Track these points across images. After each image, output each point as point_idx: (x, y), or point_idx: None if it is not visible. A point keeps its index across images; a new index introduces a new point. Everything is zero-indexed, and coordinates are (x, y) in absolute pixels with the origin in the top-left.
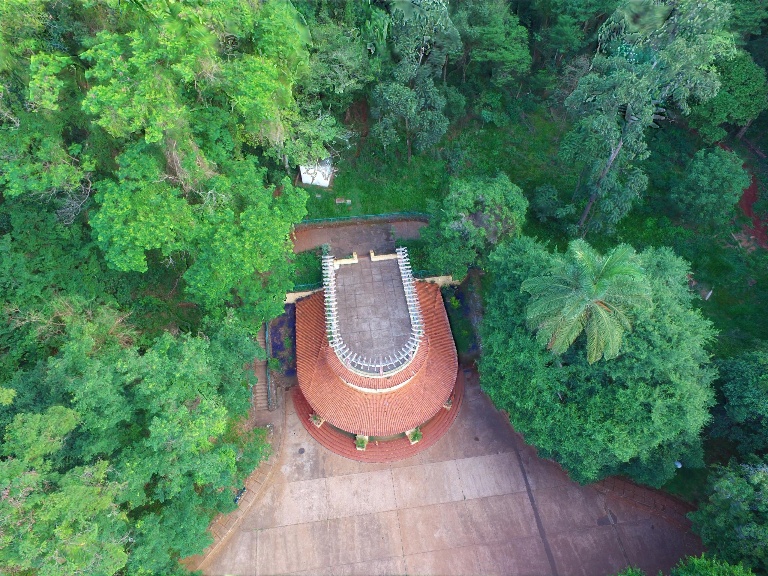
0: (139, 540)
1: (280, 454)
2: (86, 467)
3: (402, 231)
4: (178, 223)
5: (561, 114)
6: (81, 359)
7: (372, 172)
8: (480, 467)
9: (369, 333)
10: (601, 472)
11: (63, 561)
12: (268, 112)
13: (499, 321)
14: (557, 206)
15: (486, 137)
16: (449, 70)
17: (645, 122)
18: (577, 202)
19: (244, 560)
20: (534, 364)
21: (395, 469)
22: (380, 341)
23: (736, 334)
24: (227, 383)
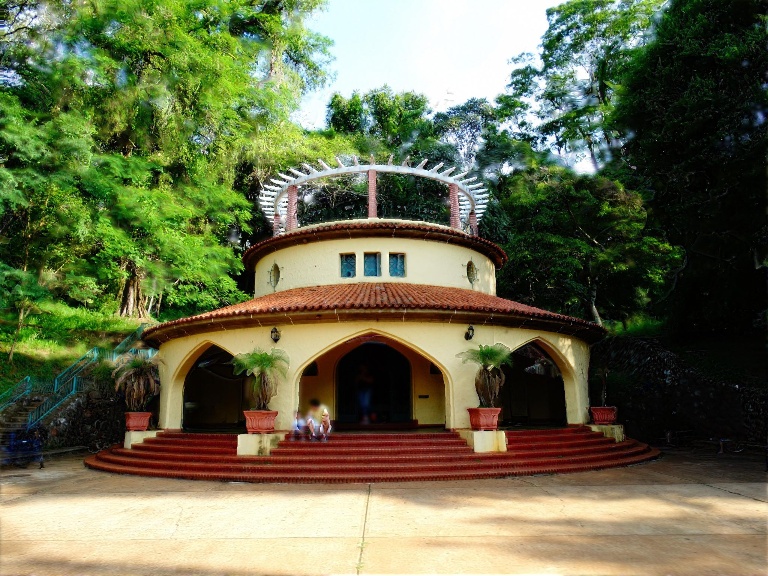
0: None
1: None
2: None
3: None
4: None
5: None
6: None
7: None
8: None
9: None
10: None
11: None
12: None
13: None
14: None
15: None
16: None
17: None
18: None
19: None
20: None
21: (389, 488)
22: None
23: None
24: None
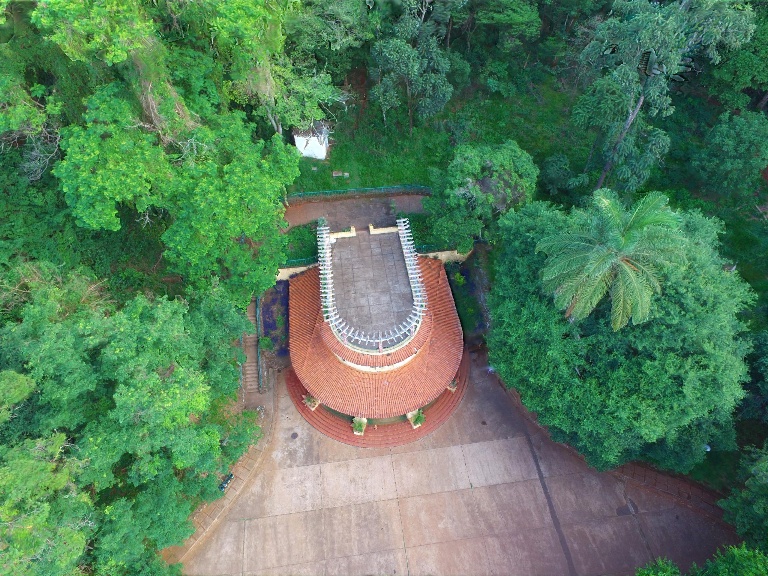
0: (108, 528)
1: (271, 439)
2: (39, 440)
3: (403, 205)
4: (153, 174)
5: (572, 81)
6: (43, 324)
7: (371, 144)
8: (488, 453)
9: (368, 308)
10: (621, 457)
11: (4, 547)
12: (252, 40)
13: (510, 290)
14: (569, 177)
15: (492, 108)
16: (453, 37)
17: (671, 71)
18: (589, 174)
19: (230, 553)
20: (550, 335)
21: (396, 455)
22: (379, 316)
23: (764, 310)
24: (213, 361)
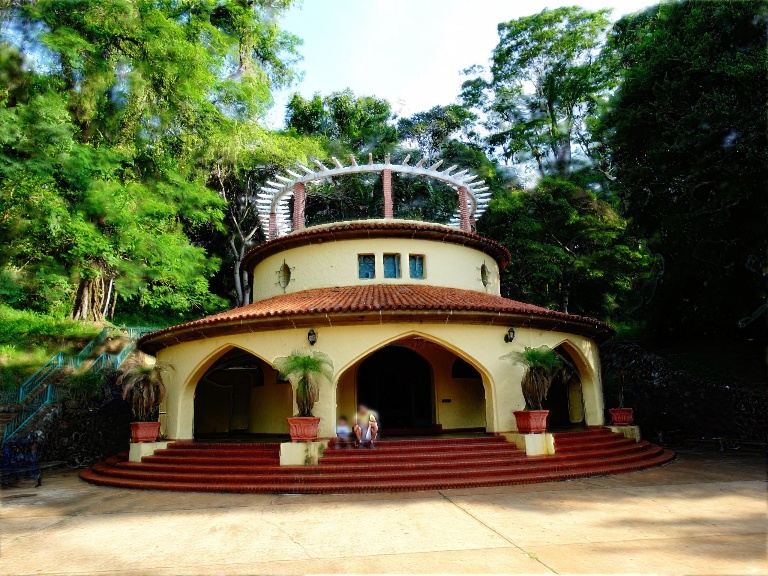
0: None
1: None
2: None
3: None
4: None
5: None
6: None
7: None
8: None
9: None
10: None
11: None
12: None
13: None
14: None
15: None
16: None
17: None
18: None
19: None
20: None
21: (466, 495)
22: None
23: None
24: None
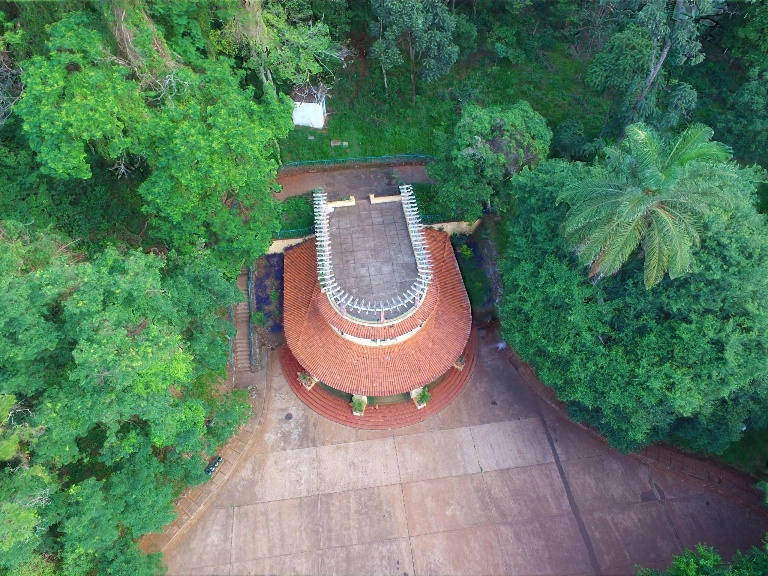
0: (74, 510)
1: (263, 420)
2: None
3: (406, 175)
4: (127, 113)
5: (586, 43)
6: None
7: (372, 113)
8: (499, 435)
9: (368, 278)
10: (647, 436)
11: None
12: None
13: (526, 251)
14: (583, 143)
15: (499, 76)
16: (458, 1)
17: (703, 10)
18: None
19: (217, 542)
20: (571, 298)
21: (399, 437)
22: (381, 287)
23: None
24: (199, 333)
